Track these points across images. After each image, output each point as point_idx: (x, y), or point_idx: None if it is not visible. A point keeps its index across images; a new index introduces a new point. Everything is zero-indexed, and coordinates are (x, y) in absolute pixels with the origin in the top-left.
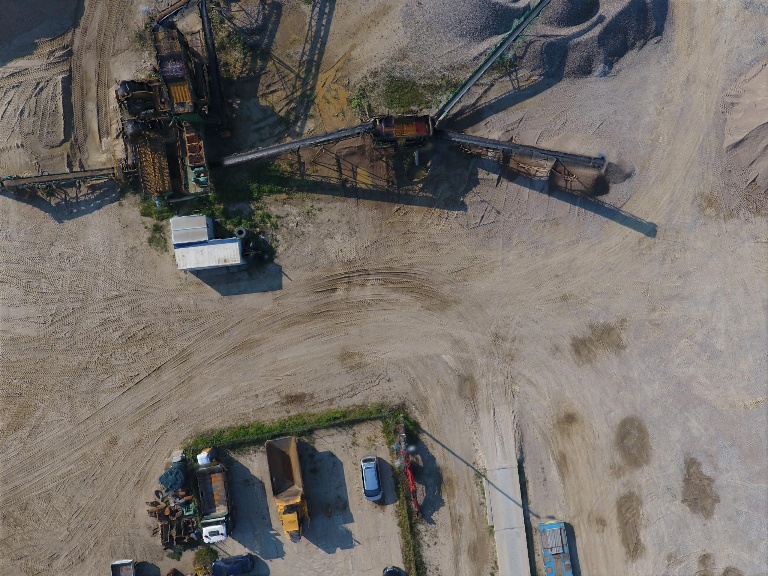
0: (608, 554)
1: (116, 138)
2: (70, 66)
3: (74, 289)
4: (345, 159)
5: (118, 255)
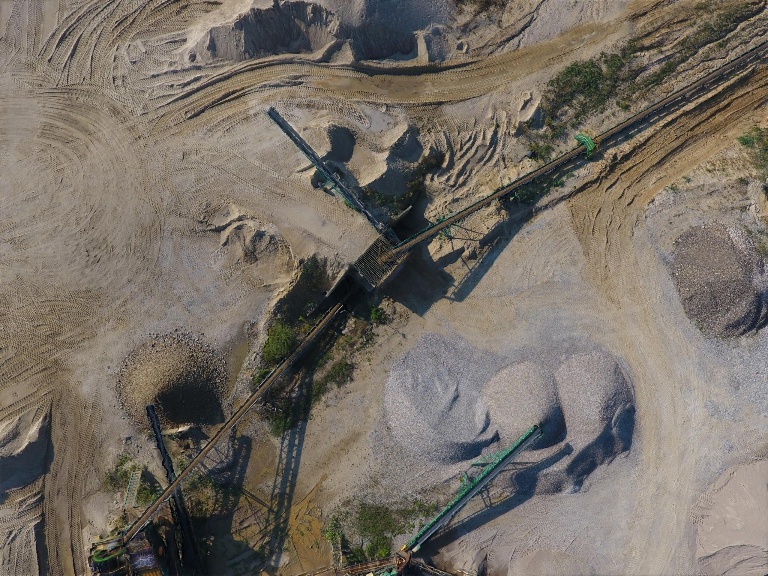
0: None
1: None
2: (42, 510)
3: None
4: None
5: None
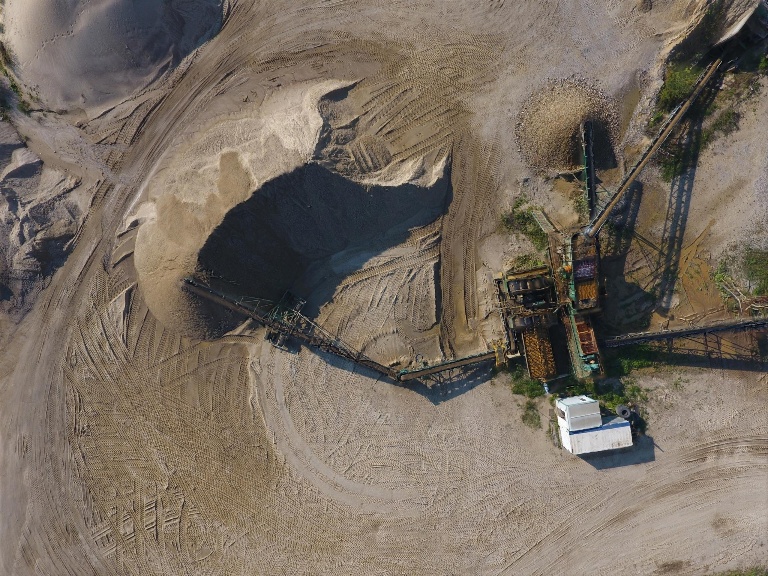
0: None
1: (485, 318)
2: (439, 251)
3: (453, 469)
4: (710, 332)
5: (493, 433)
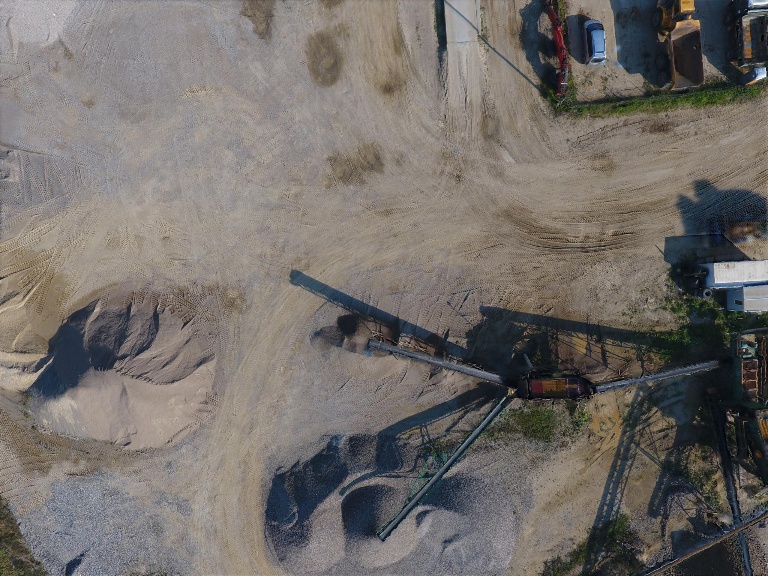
0: None
1: None
2: None
3: None
4: (597, 363)
5: None
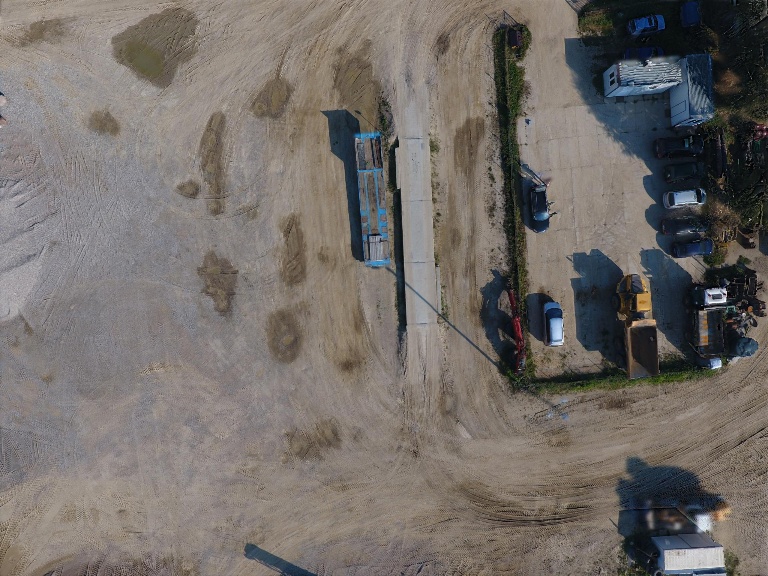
0: (319, 224)
1: None
2: None
3: None
4: None
5: (767, 550)
